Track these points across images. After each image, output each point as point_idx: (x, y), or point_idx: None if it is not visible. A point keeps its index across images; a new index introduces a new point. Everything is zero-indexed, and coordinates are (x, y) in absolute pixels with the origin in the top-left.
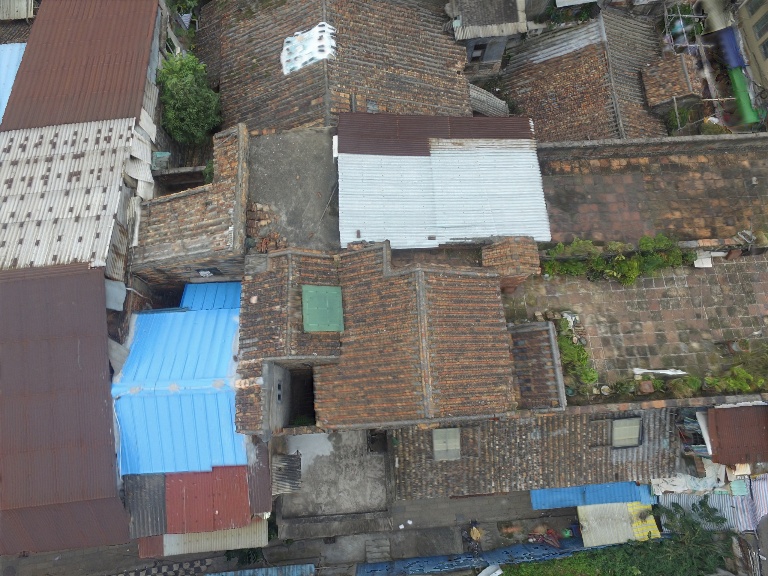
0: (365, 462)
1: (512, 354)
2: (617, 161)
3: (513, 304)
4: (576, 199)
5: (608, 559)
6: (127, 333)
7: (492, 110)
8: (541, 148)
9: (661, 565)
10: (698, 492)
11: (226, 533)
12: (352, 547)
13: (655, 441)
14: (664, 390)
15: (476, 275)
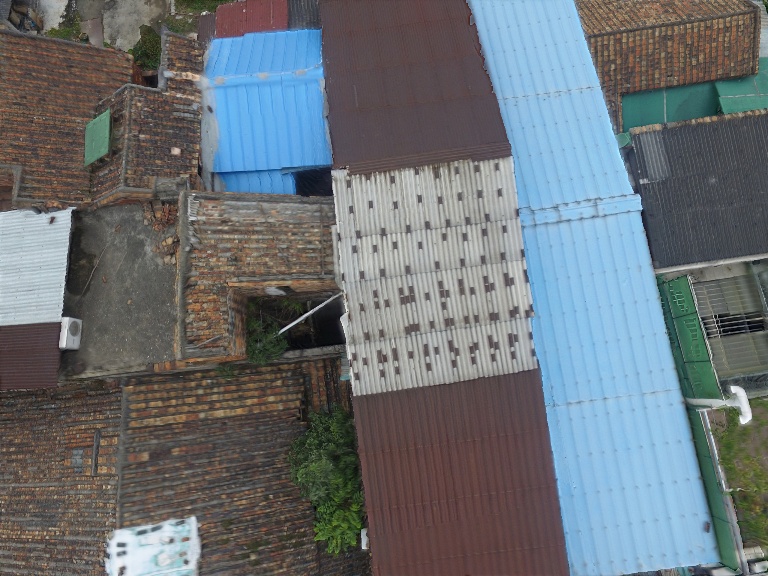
0: None
1: None
2: None
3: None
4: None
5: None
6: None
7: None
8: None
9: None
10: None
11: None
12: None
13: None
14: None
15: None
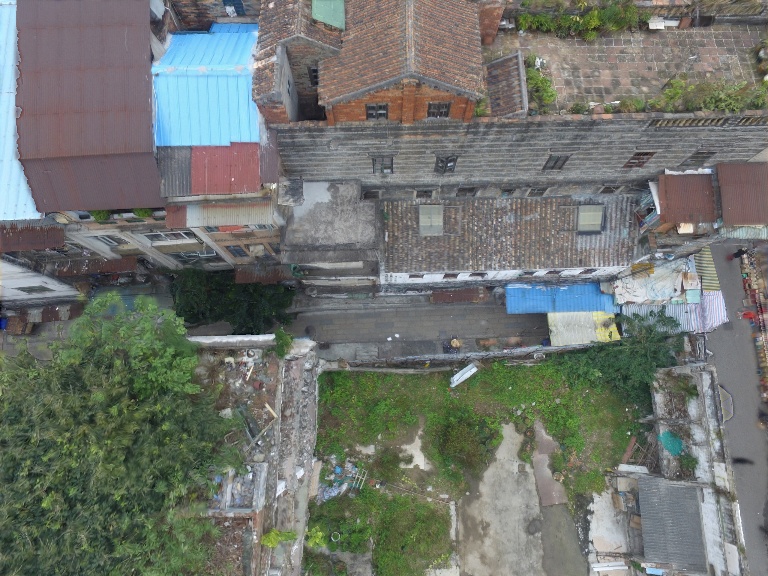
0: (358, 208)
1: (486, 81)
2: None
3: (491, 53)
4: None
5: (573, 365)
6: (164, 40)
7: None
8: None
9: (619, 362)
10: (657, 302)
11: (239, 213)
12: (344, 353)
13: (616, 230)
14: (613, 109)
15: None
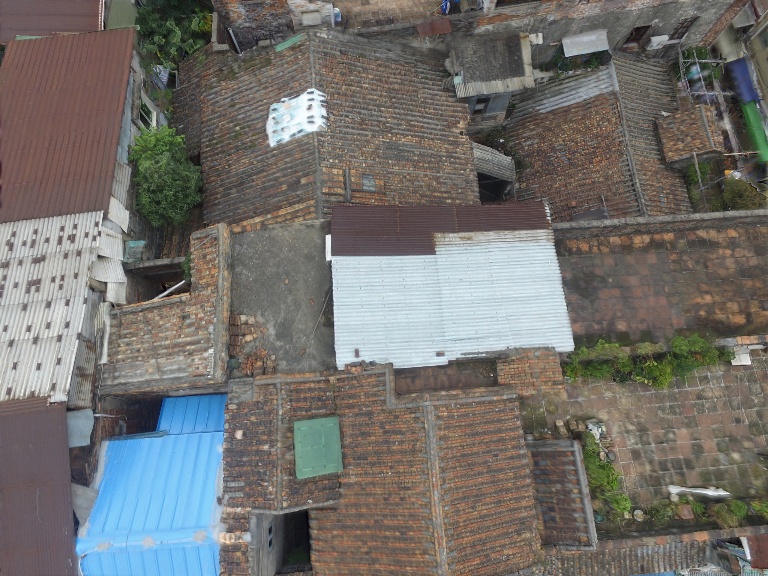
0: None
1: (533, 476)
2: (639, 238)
3: (531, 411)
4: (596, 283)
5: None
6: (96, 468)
7: (498, 169)
8: (556, 229)
9: None
10: None
11: None
12: None
13: None
14: (705, 517)
15: (492, 400)
